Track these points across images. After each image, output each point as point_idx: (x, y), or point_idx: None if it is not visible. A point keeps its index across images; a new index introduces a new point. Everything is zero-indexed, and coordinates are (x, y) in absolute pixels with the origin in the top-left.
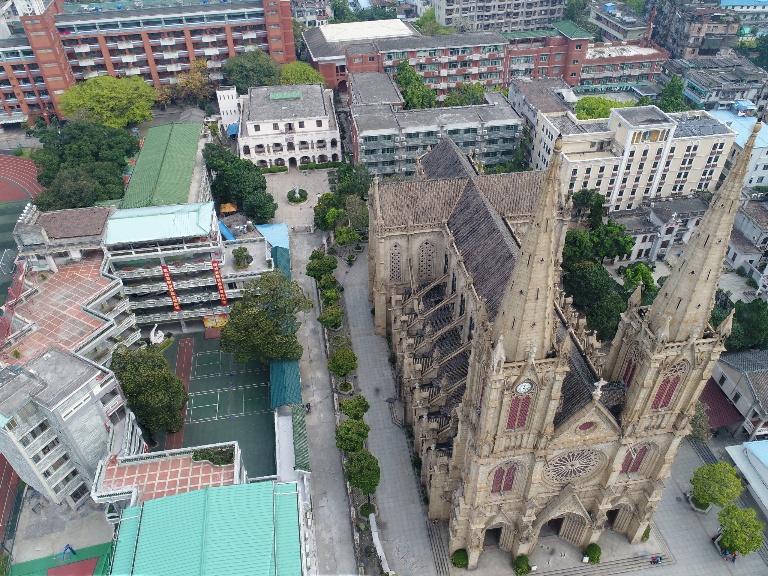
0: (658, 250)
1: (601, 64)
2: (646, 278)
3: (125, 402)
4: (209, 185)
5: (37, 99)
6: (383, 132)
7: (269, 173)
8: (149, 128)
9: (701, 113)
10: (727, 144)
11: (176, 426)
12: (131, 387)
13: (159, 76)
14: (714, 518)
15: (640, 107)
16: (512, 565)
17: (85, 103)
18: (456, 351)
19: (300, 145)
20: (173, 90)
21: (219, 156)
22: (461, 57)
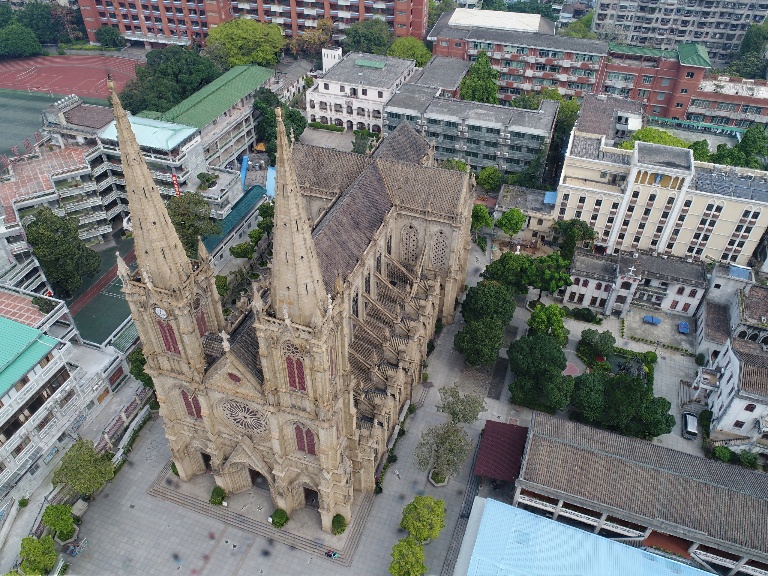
0: (613, 303)
1: (717, 100)
2: (552, 319)
3: (31, 250)
4: (254, 123)
5: (200, 29)
6: (406, 112)
7: (327, 130)
8: (236, 66)
9: (763, 174)
10: (764, 215)
11: (72, 285)
12: (30, 238)
13: (299, 28)
14: None
15: (672, 147)
16: None
17: (221, 38)
18: None
19: (361, 111)
20: (301, 42)
21: (266, 100)
22: (550, 60)
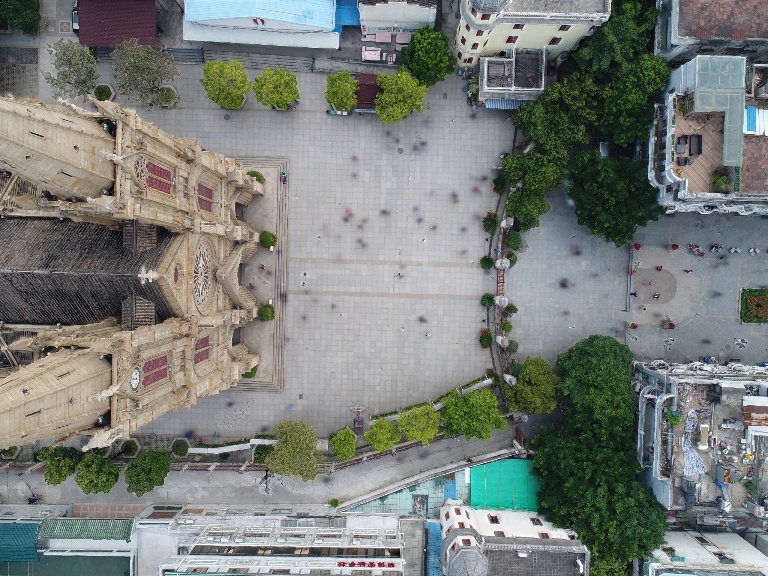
0: None
1: None
2: None
3: None
4: None
5: None
6: None
7: None
8: None
9: None
10: None
11: None
12: None
13: None
14: (253, 93)
15: None
16: (263, 321)
17: None
18: (1, 345)
19: None
20: None
21: None
22: None
